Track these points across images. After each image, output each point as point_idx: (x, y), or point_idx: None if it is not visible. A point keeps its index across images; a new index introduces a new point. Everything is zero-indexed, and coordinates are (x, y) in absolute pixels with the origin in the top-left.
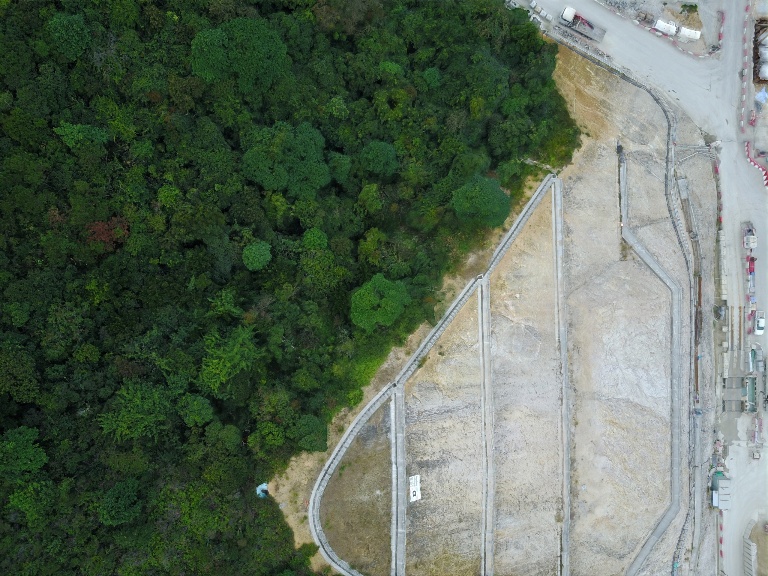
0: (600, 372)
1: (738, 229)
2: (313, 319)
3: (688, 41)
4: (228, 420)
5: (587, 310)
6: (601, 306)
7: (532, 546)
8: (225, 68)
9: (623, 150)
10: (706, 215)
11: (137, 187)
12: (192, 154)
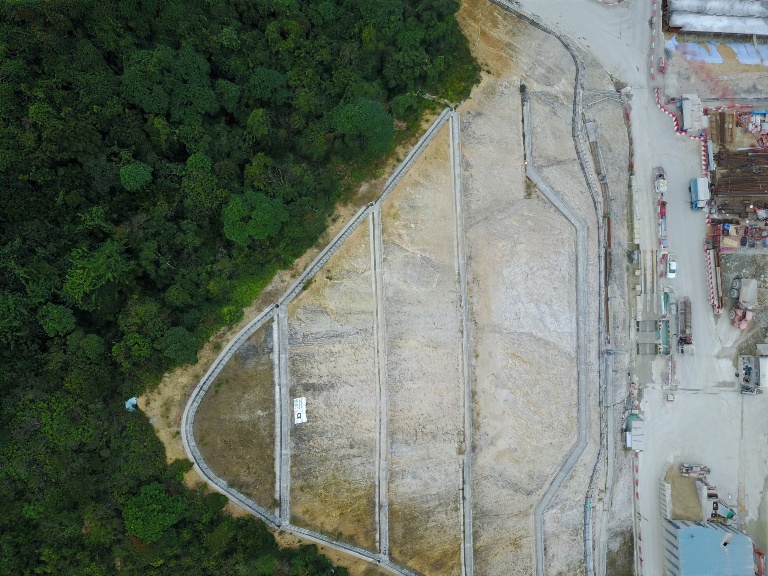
0: (501, 305)
1: (650, 174)
2: (190, 237)
3: None
4: (94, 332)
5: (486, 243)
6: (501, 239)
7: (431, 477)
8: None
9: (526, 89)
10: (617, 159)
11: (7, 103)
12: (71, 76)
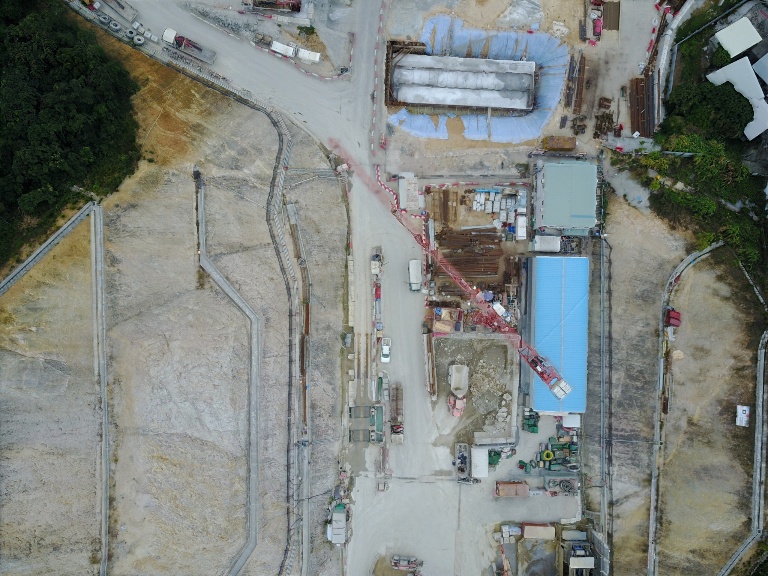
0: (145, 406)
1: (369, 254)
2: None
3: (311, 63)
4: None
5: (129, 342)
6: (147, 338)
7: None
8: None
9: (201, 175)
10: (327, 240)
11: None
12: None
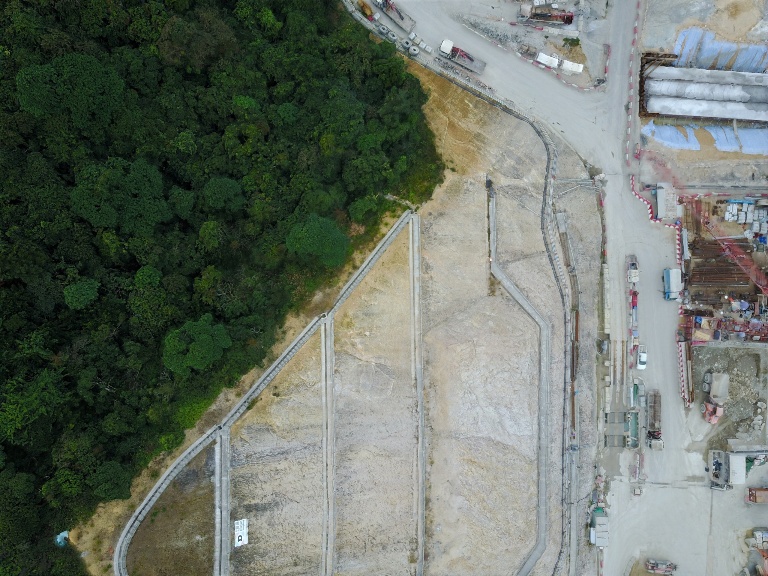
0: (457, 410)
1: (622, 262)
2: (131, 361)
3: (572, 74)
4: (26, 466)
5: (444, 348)
6: (460, 343)
7: None
8: (55, 104)
9: (492, 185)
10: (588, 248)
11: None
12: (19, 190)
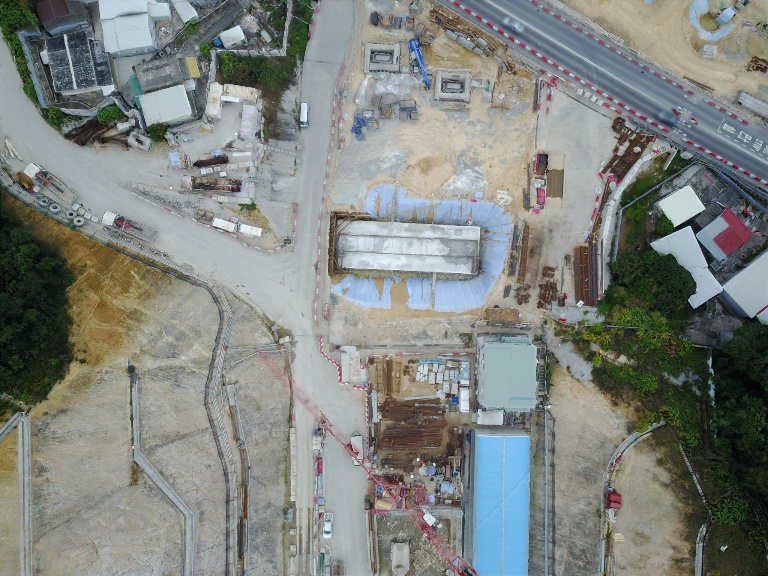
0: None
1: (312, 426)
2: None
3: (254, 236)
4: None
5: (56, 554)
6: (75, 548)
7: None
8: None
9: (135, 370)
10: (269, 416)
11: None
12: None
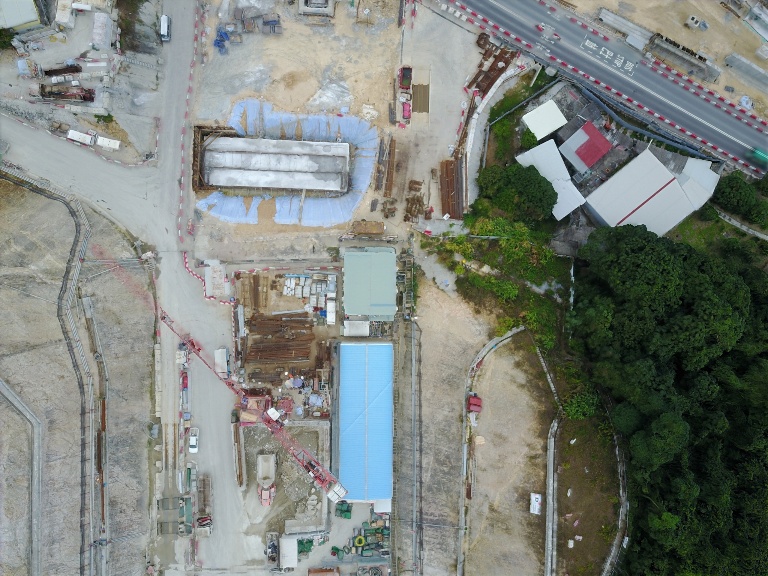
0: None
1: (177, 342)
2: None
3: (113, 150)
4: None
5: None
6: None
7: None
8: None
9: None
10: (130, 331)
11: None
12: None
